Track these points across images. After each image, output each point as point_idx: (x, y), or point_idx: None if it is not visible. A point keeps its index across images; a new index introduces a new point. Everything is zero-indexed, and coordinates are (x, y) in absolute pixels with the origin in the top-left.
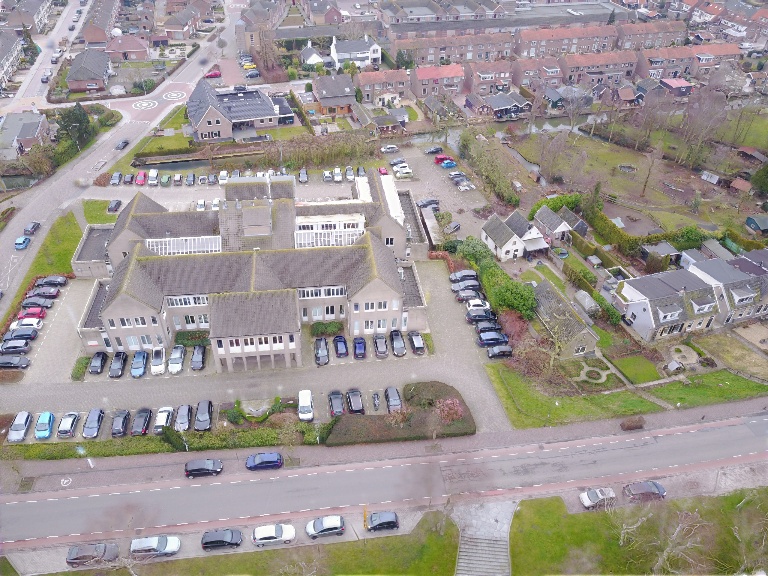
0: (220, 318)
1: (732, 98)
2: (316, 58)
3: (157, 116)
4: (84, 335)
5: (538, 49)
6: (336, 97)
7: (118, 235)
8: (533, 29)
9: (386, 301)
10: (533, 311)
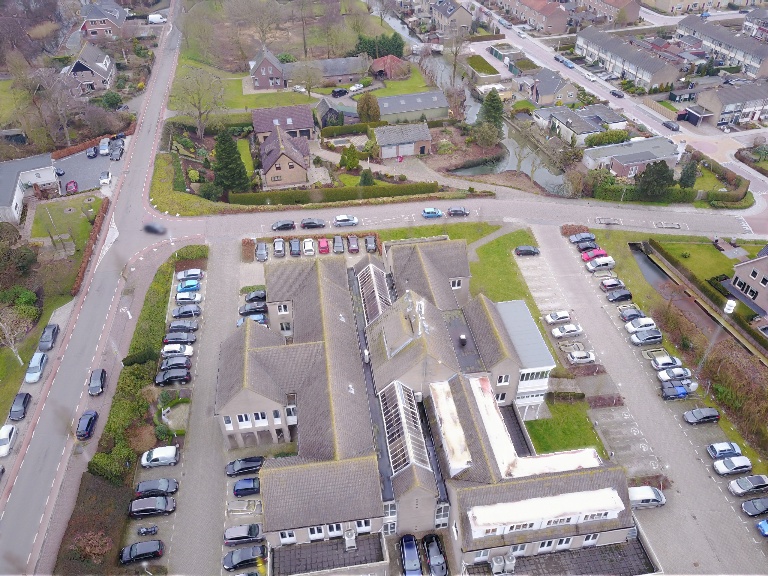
0: (232, 340)
1: None
2: None
3: None
4: None
5: None
6: None
7: None
8: None
9: None
10: None
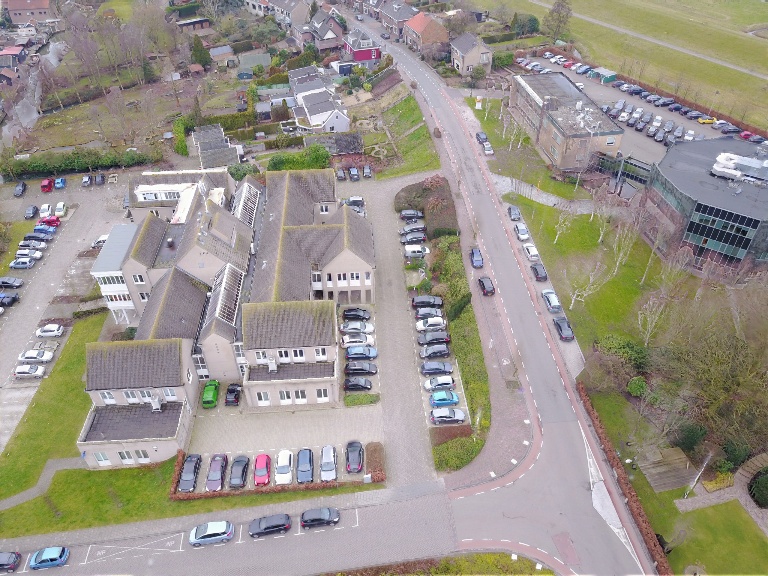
0: (362, 253)
1: (47, 45)
2: None
3: None
4: None
5: None
6: None
7: (181, 356)
8: None
9: None
10: None
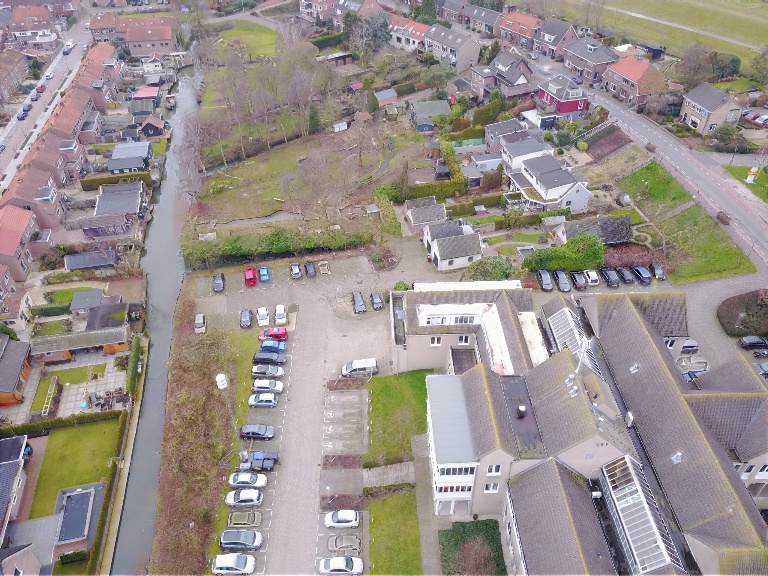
0: None
1: (177, 83)
2: None
3: None
4: None
5: None
6: None
7: None
8: None
9: None
10: None
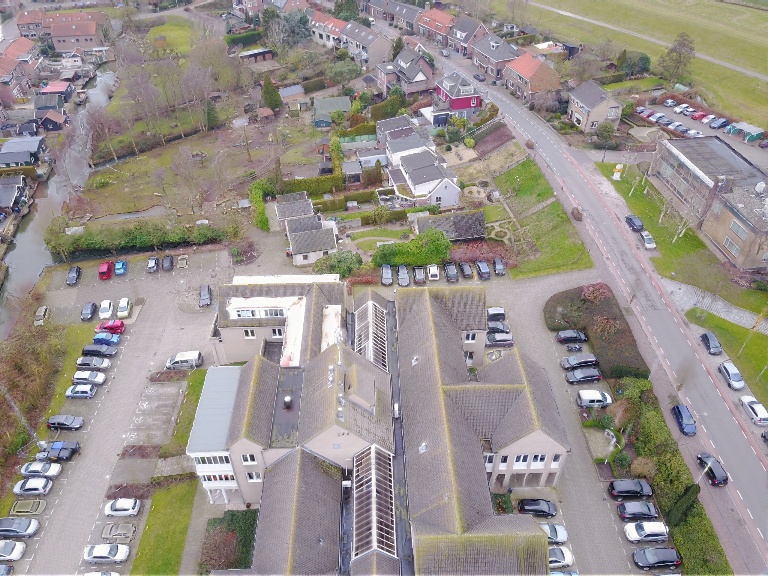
0: (554, 430)
1: (95, 78)
2: None
3: None
4: None
5: None
6: None
7: None
8: None
9: None
10: None
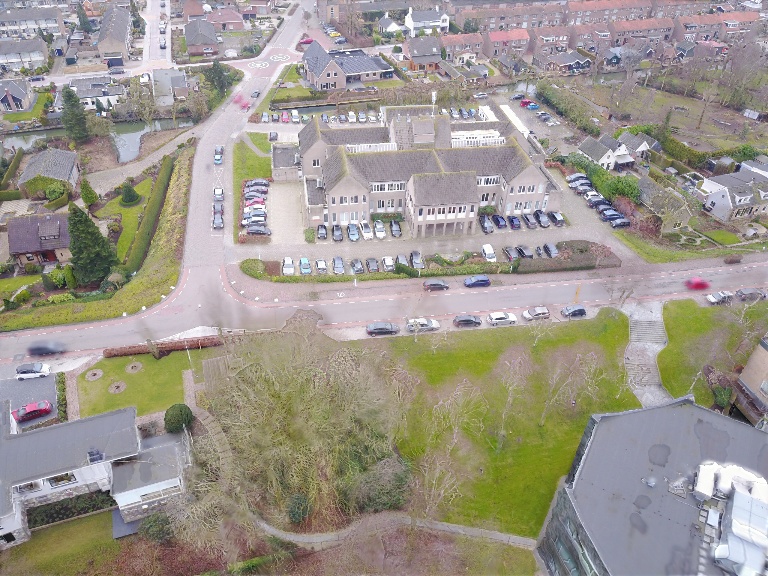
0: (422, 192)
1: None
2: (395, 26)
3: (273, 73)
4: (311, 211)
5: (583, 19)
6: (425, 56)
7: (313, 145)
8: (579, 1)
9: (534, 185)
10: (637, 199)
